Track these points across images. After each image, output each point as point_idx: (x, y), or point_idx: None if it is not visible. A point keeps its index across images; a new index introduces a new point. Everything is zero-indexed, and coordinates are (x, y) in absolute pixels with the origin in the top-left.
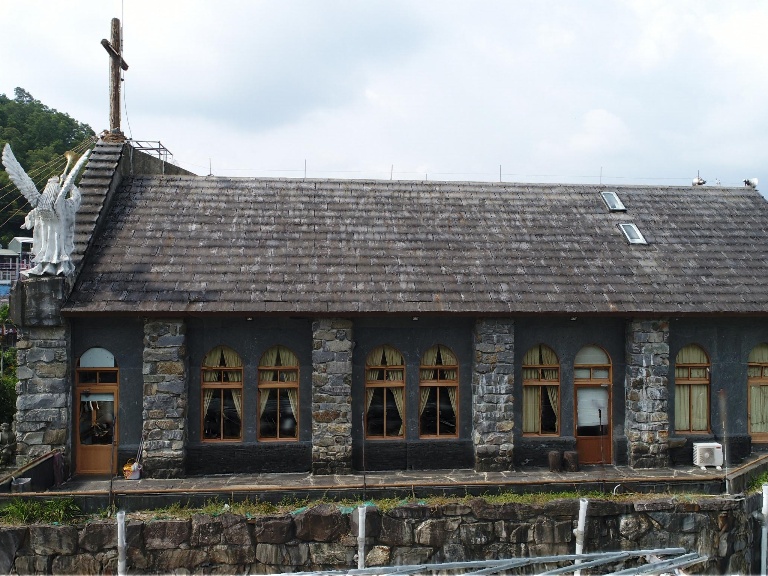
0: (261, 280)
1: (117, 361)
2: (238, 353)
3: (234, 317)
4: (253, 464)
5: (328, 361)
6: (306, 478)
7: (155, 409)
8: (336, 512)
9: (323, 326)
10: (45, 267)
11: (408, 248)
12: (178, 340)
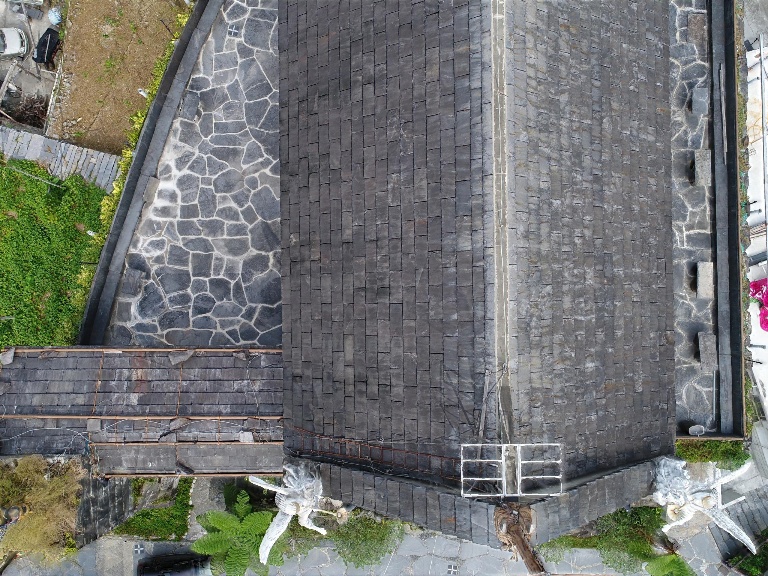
0: None
1: None
2: None
3: None
4: None
5: None
6: None
7: None
8: (748, 227)
9: None
10: None
11: None
12: None
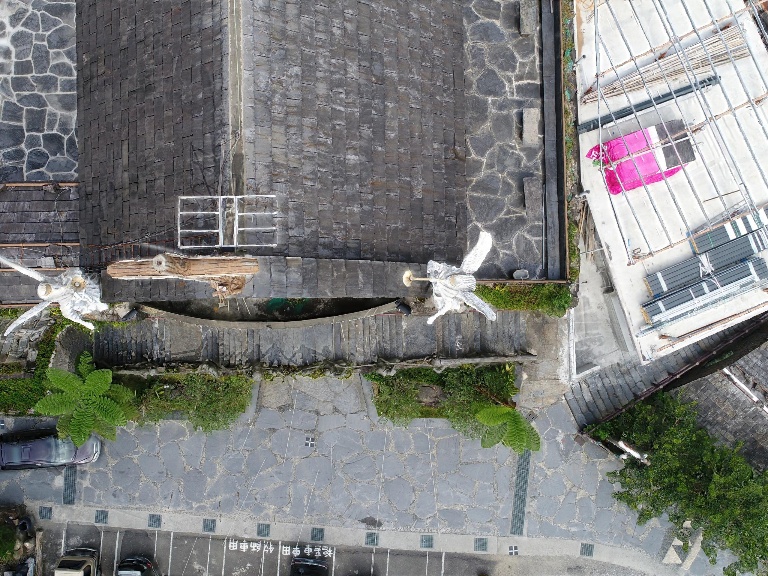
0: (431, 90)
1: None
2: None
3: None
4: None
5: None
6: None
7: None
8: (574, 74)
9: None
10: None
11: None
12: None
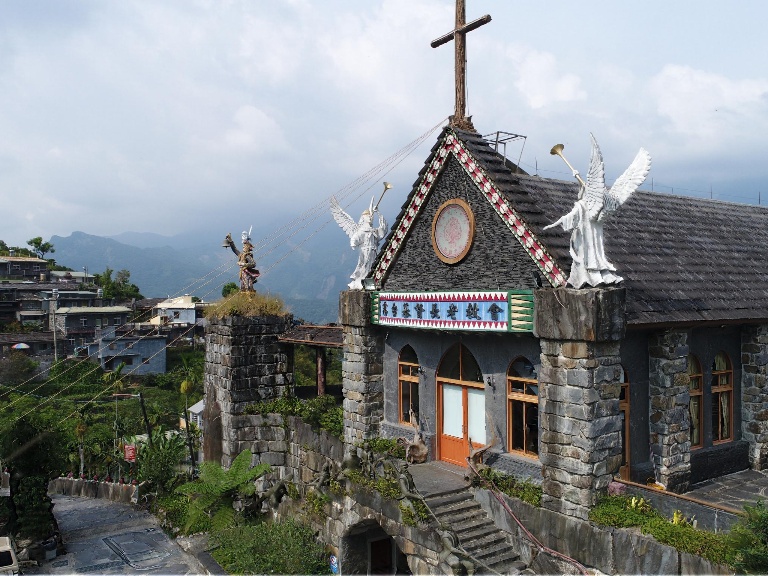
0: (710, 288)
1: (628, 376)
2: (701, 360)
3: (708, 325)
4: (718, 468)
5: (766, 363)
6: (765, 474)
7: (674, 423)
8: None
9: (764, 331)
10: (609, 275)
11: (745, 258)
12: (687, 350)
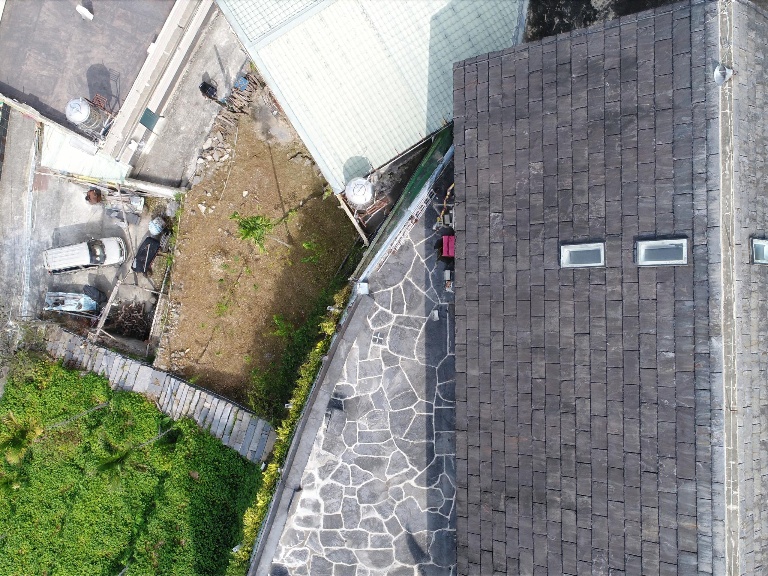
0: None
1: None
2: None
3: None
4: None
5: None
6: None
7: None
8: None
9: None
10: None
11: None
12: None
